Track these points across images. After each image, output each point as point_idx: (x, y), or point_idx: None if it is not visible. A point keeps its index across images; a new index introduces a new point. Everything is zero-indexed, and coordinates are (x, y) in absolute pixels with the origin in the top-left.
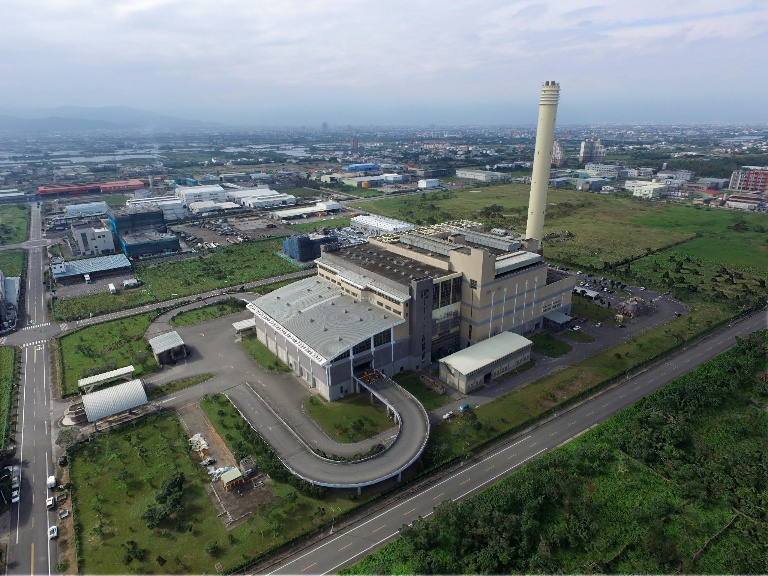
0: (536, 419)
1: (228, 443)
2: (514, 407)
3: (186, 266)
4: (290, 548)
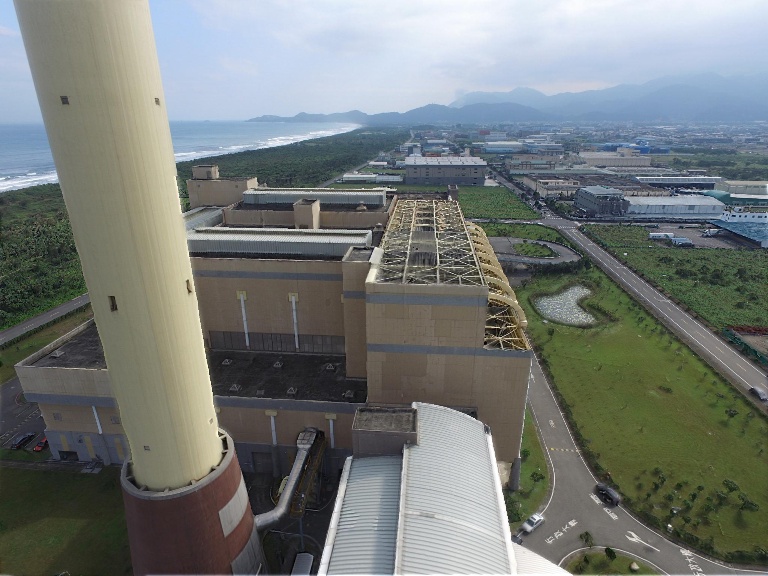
0: None
1: None
2: None
3: None
4: None
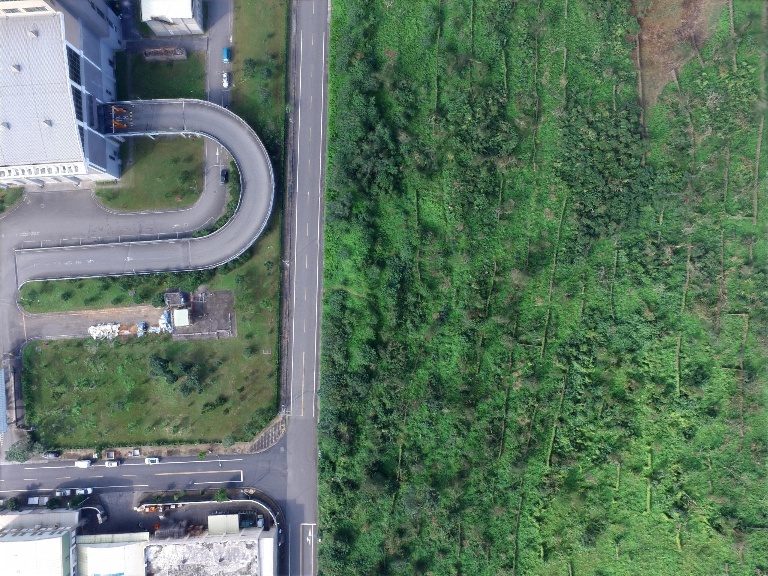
0: (288, 4)
1: (124, 304)
2: (258, 6)
3: None
4: (283, 299)
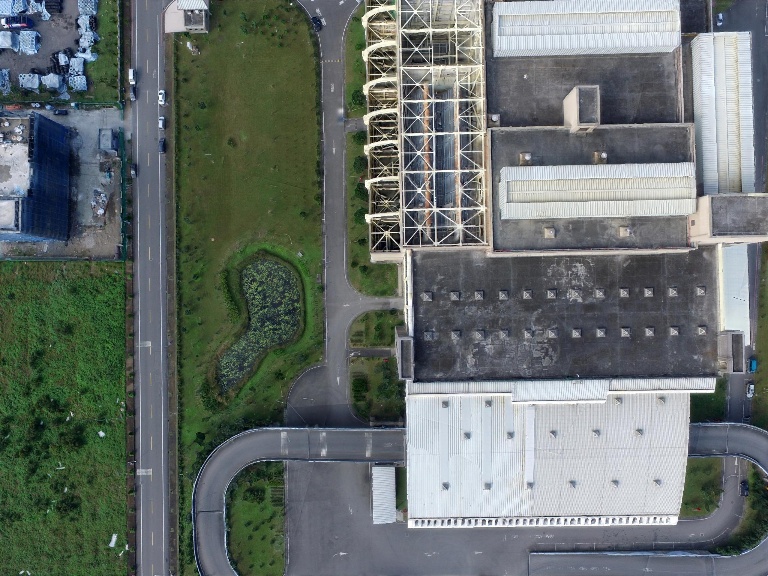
0: None
1: None
2: None
3: None
4: None
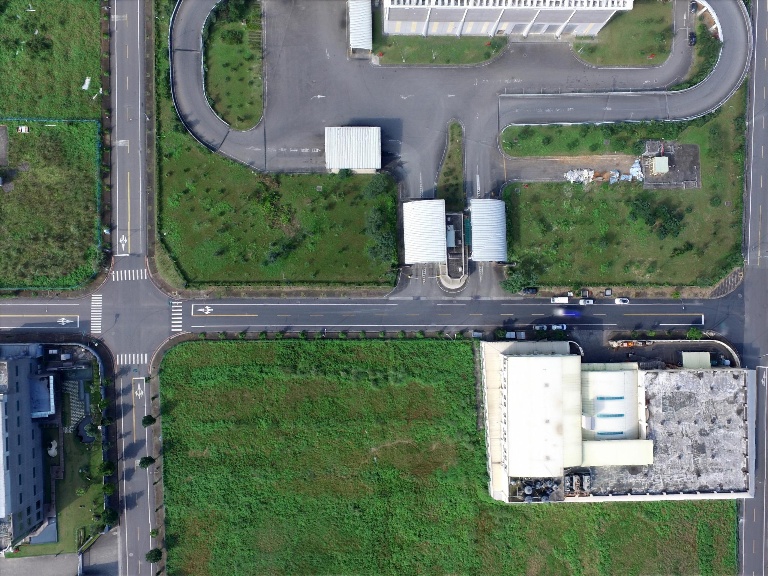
0: None
1: (598, 152)
2: None
3: None
4: None
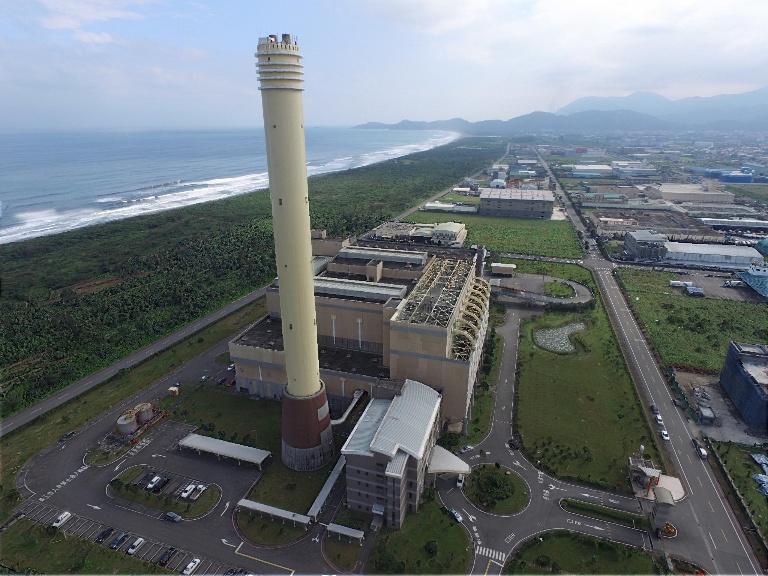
0: None
1: None
2: None
3: (761, 322)
4: None
